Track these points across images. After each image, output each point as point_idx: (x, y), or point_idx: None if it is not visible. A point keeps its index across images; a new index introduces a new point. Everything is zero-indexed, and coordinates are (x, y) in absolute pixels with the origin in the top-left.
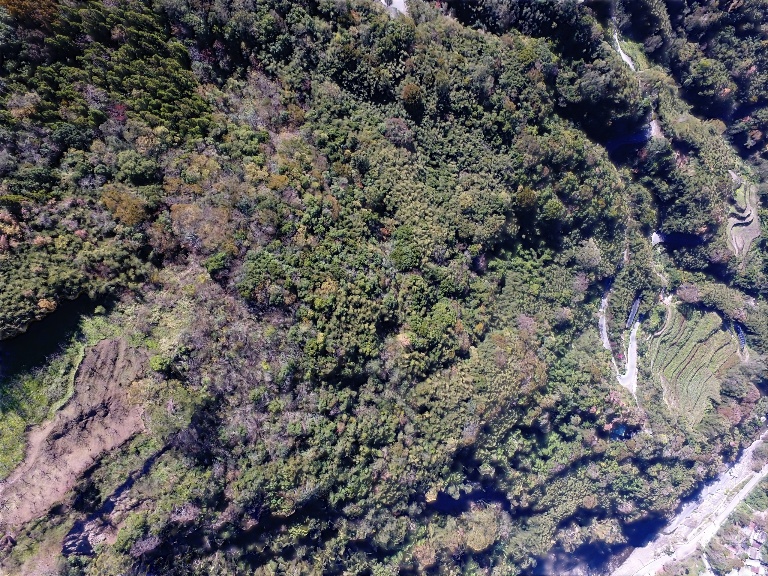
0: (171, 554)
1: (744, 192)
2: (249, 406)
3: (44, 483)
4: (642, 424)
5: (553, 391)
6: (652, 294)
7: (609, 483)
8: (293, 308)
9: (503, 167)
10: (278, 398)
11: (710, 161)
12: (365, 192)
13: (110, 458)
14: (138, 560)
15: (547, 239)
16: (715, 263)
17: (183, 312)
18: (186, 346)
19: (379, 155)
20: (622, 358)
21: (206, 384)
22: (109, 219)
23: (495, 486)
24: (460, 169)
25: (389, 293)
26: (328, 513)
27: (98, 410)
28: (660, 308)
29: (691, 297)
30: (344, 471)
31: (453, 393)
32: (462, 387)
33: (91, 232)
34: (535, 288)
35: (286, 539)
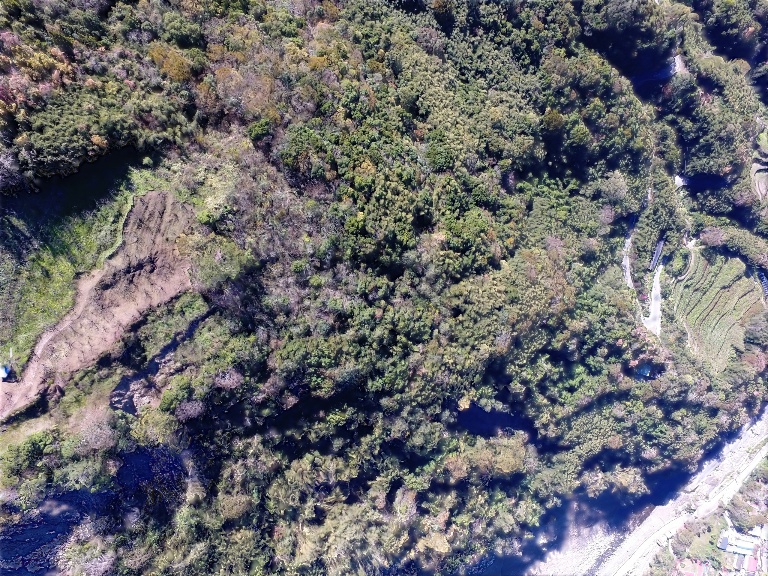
0: (212, 430)
1: (767, 137)
2: (291, 278)
3: (92, 333)
4: (667, 365)
5: (580, 319)
6: (676, 235)
7: (634, 423)
8: (334, 184)
9: (531, 87)
10: (319, 274)
11: (734, 100)
12: (399, 92)
13: (156, 316)
14: (181, 427)
15: (573, 169)
16: (739, 207)
17: (227, 175)
18: (231, 206)
19: (412, 58)
20: (646, 300)
21: (251, 244)
22: (156, 74)
23: (523, 412)
24: (489, 86)
25: (424, 189)
26: (364, 407)
27: (145, 264)
28: (684, 251)
29: (715, 239)
30: (382, 359)
31: (486, 299)
32: (495, 294)
33: (139, 84)
34: (562, 214)
35: (324, 427)
